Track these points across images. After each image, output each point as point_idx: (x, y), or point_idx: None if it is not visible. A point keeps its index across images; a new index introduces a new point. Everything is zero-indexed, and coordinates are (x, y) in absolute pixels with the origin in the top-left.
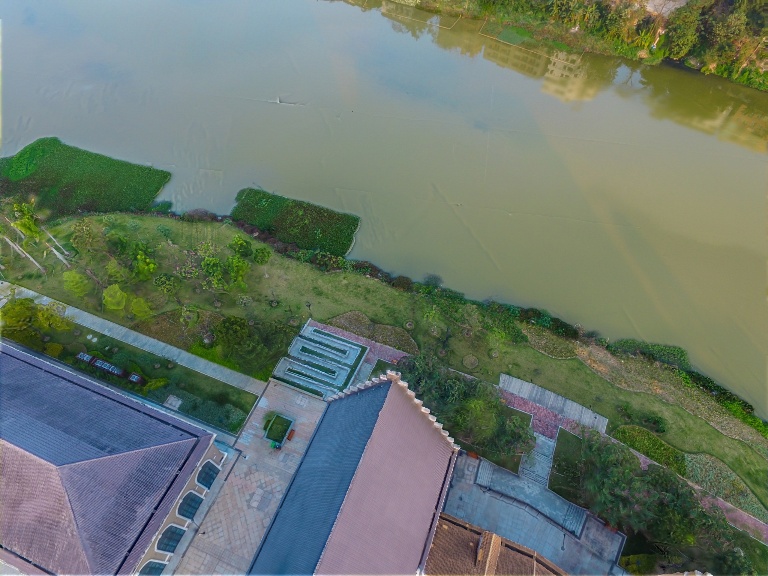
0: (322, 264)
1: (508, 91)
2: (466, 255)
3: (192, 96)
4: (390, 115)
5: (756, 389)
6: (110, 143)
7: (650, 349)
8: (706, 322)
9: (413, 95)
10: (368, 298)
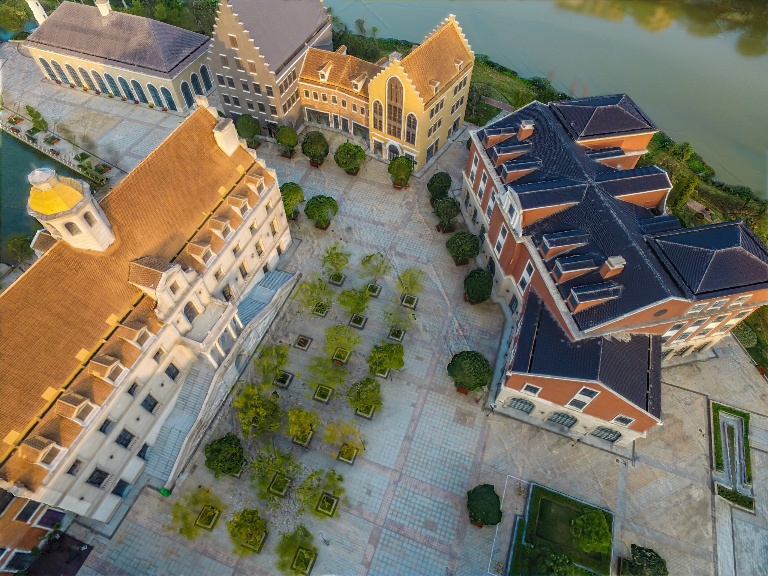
0: None
1: None
2: (370, 23)
3: None
4: None
5: (523, 69)
6: None
7: None
8: (506, 47)
9: None
10: None
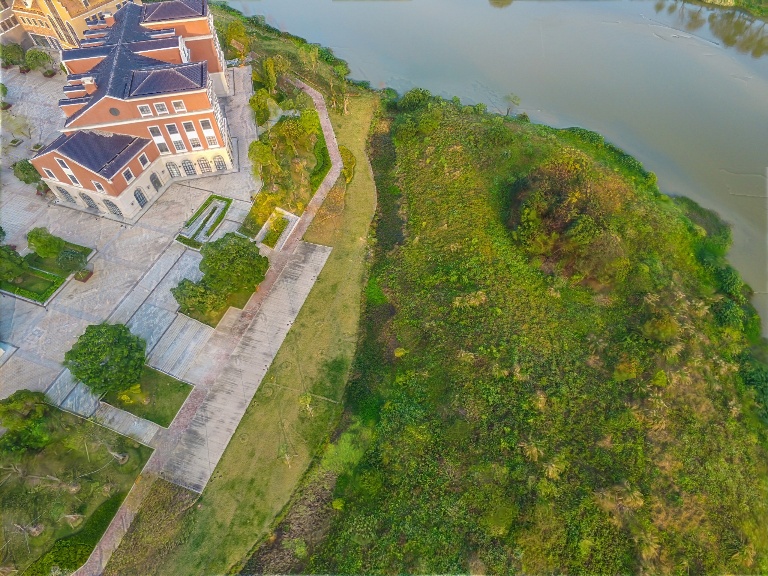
0: None
1: None
2: None
3: None
4: None
5: (250, 10)
6: None
7: (211, 2)
8: None
9: None
10: None
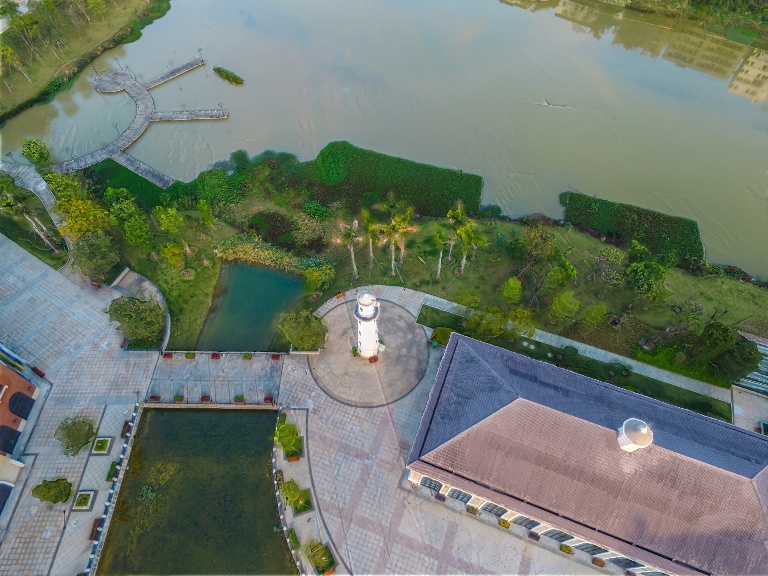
0: (694, 269)
1: (767, 92)
2: None
3: (457, 99)
4: (664, 117)
5: None
6: (405, 147)
7: None
8: None
9: (677, 97)
10: (758, 303)
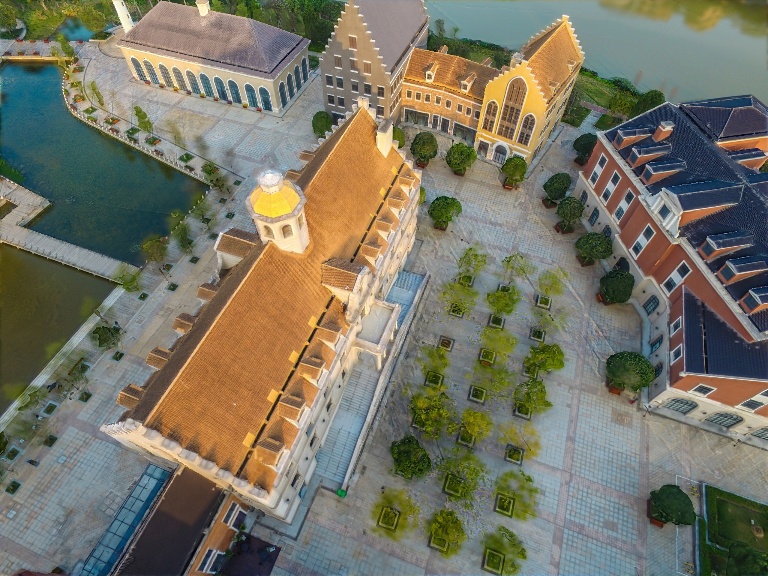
0: None
1: None
2: None
3: None
4: None
5: (601, 69)
6: None
7: None
8: None
9: None
10: None
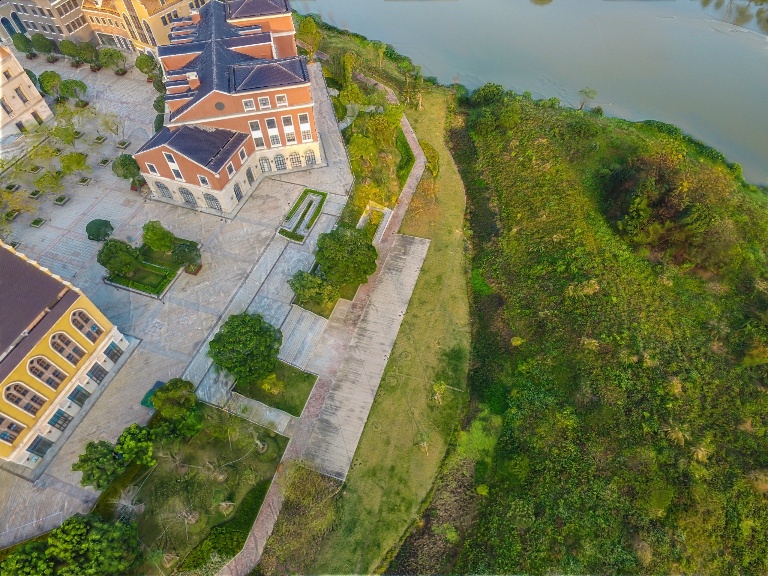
0: None
1: None
2: None
3: None
4: None
5: (304, 8)
6: None
7: None
8: None
9: None
10: None
